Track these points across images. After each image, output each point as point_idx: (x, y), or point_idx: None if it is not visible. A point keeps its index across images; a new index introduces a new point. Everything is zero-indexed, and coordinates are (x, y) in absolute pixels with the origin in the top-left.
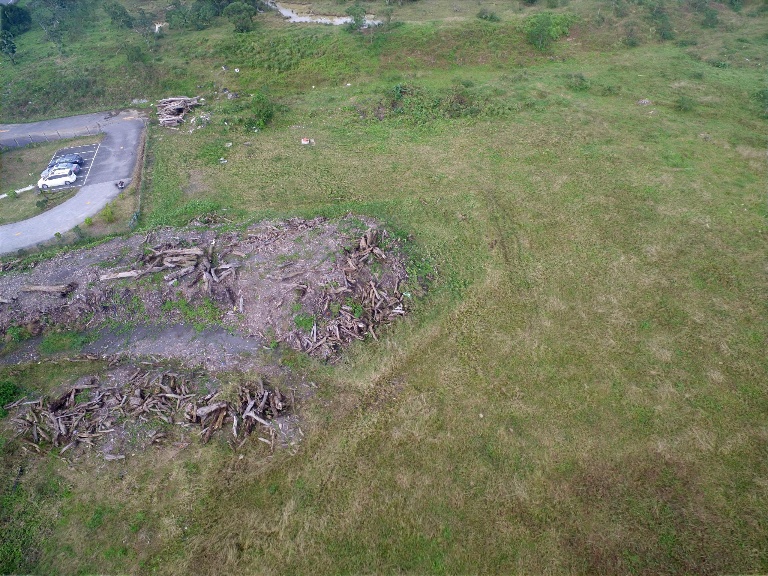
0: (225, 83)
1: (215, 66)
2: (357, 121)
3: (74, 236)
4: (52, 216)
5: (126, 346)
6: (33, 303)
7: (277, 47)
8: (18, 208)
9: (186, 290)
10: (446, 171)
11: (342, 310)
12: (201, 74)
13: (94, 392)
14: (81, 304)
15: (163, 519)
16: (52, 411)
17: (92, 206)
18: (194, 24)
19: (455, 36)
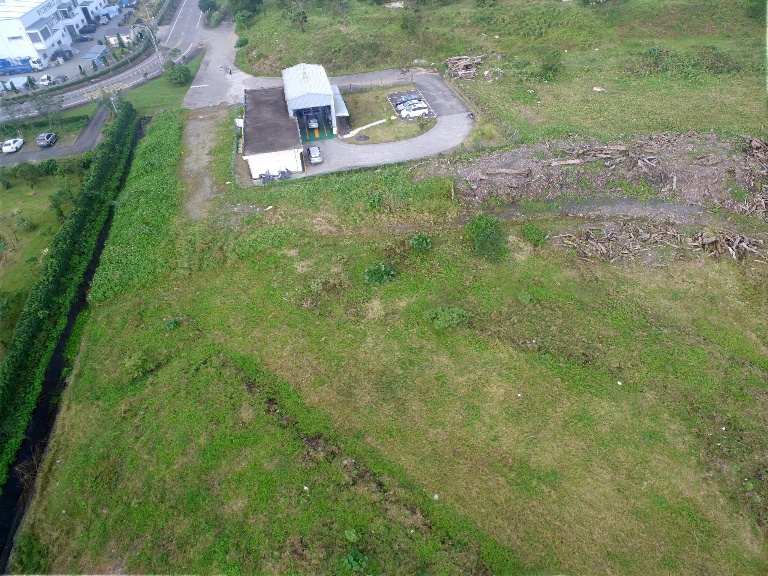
0: (491, 47)
1: (478, 33)
2: (630, 75)
3: (469, 147)
4: (435, 135)
5: (592, 209)
6: (503, 180)
7: (525, 18)
8: (400, 130)
9: (626, 173)
10: (747, 109)
11: (764, 187)
12: (469, 39)
13: (602, 232)
14: (542, 182)
15: (727, 297)
16: (586, 239)
17: (461, 129)
18: (441, 0)
19: (681, 10)
